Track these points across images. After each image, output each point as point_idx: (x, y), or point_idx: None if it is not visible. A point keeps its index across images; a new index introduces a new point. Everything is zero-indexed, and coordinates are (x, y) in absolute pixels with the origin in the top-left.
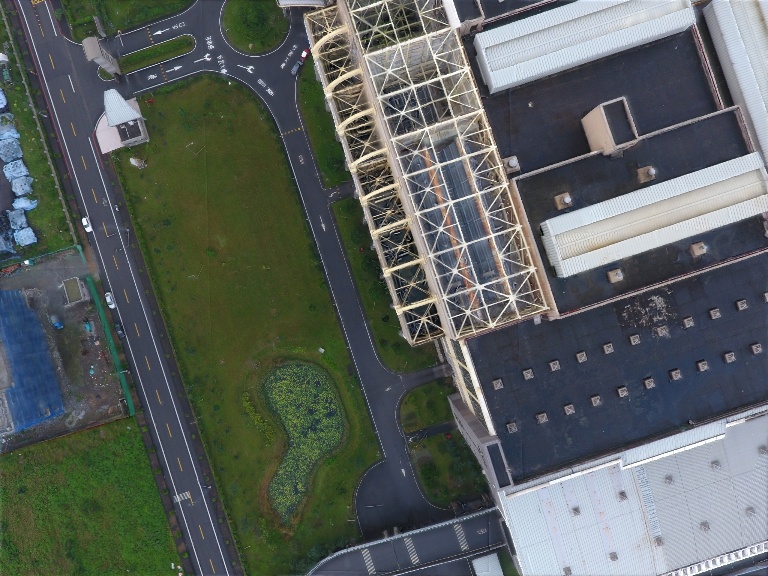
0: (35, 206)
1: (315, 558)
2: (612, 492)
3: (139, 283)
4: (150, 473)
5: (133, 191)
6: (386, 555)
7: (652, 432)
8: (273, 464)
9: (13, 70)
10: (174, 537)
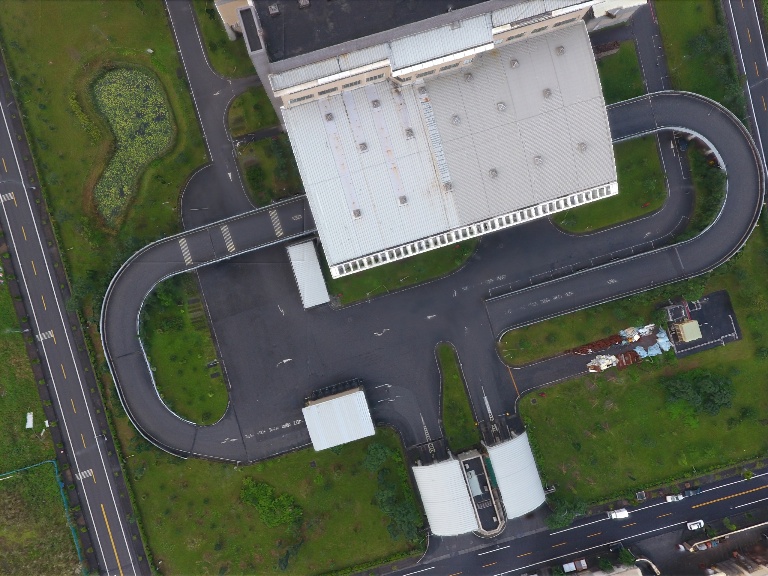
0: None
1: (132, 247)
2: (399, 130)
3: None
4: None
5: None
6: (203, 244)
7: (412, 20)
8: (99, 166)
9: None
10: None
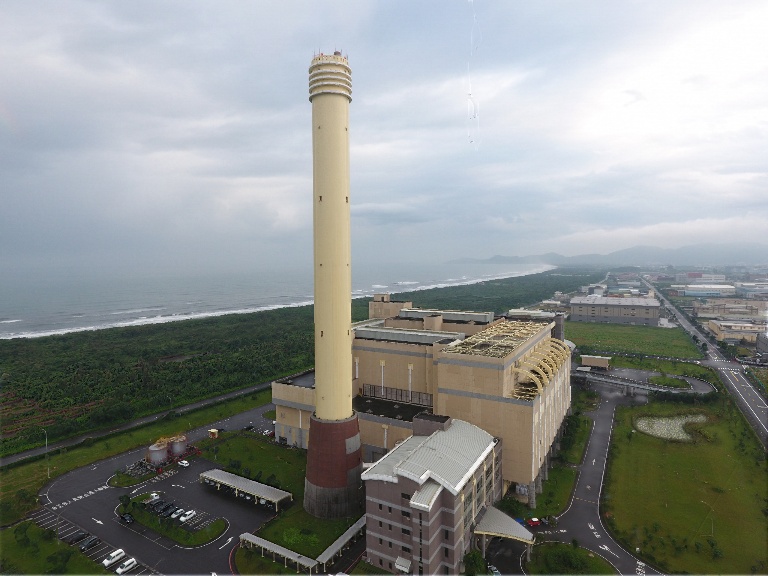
0: None
1: None
2: None
3: None
4: None
5: None
6: None
7: None
8: None
9: None
10: None
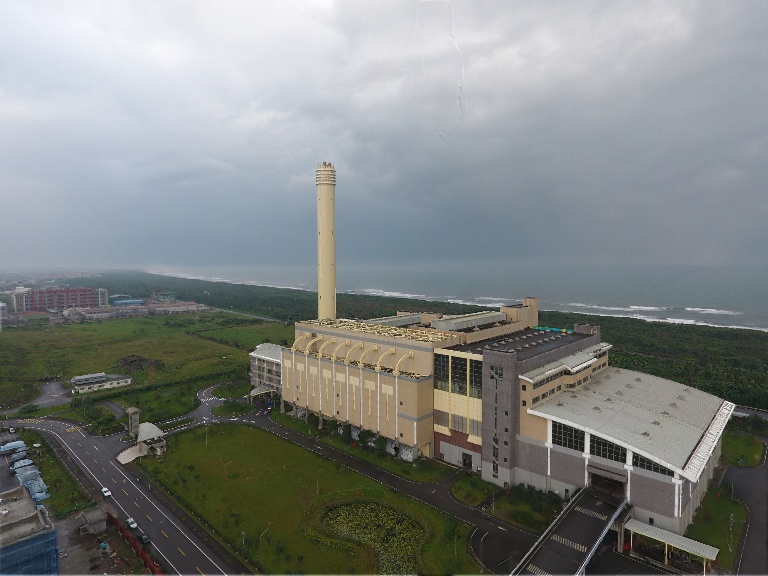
0: (48, 497)
1: None
2: None
3: (163, 509)
4: None
5: None
6: (553, 560)
7: None
8: (370, 572)
9: None
10: None
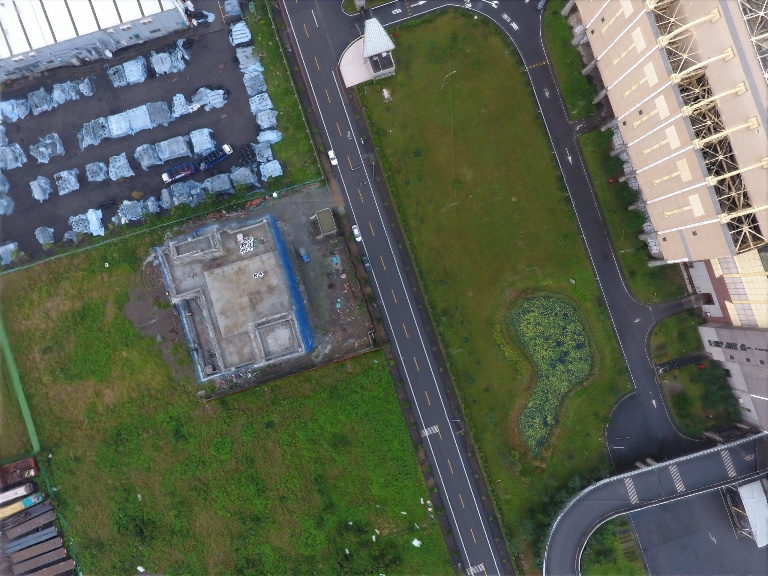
0: (280, 139)
1: (577, 488)
2: None
3: (384, 216)
4: (399, 407)
5: (379, 124)
6: (650, 483)
7: None
8: (523, 396)
9: (257, 4)
10: (423, 471)
